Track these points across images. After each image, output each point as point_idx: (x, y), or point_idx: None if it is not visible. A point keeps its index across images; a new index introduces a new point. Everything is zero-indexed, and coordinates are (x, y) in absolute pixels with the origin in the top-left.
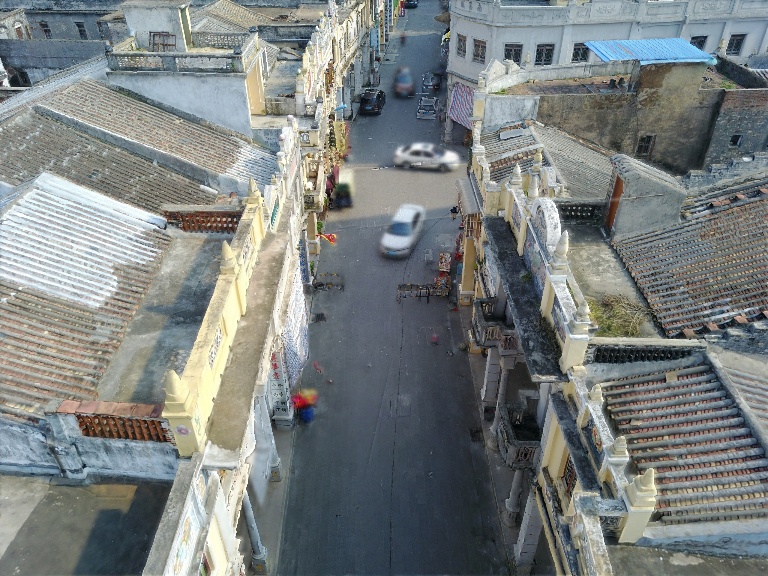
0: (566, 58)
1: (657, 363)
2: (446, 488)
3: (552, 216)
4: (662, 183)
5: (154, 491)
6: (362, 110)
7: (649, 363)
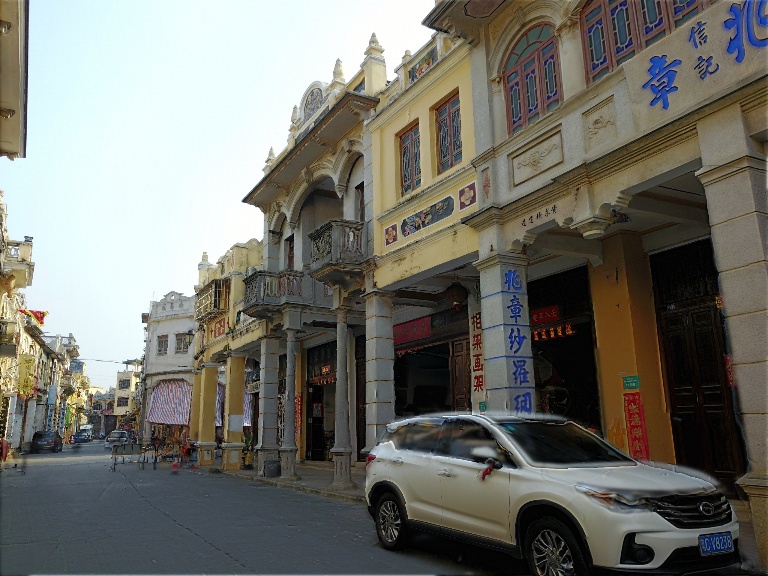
0: None
1: None
2: None
3: None
4: None
5: None
6: (33, 446)
7: None
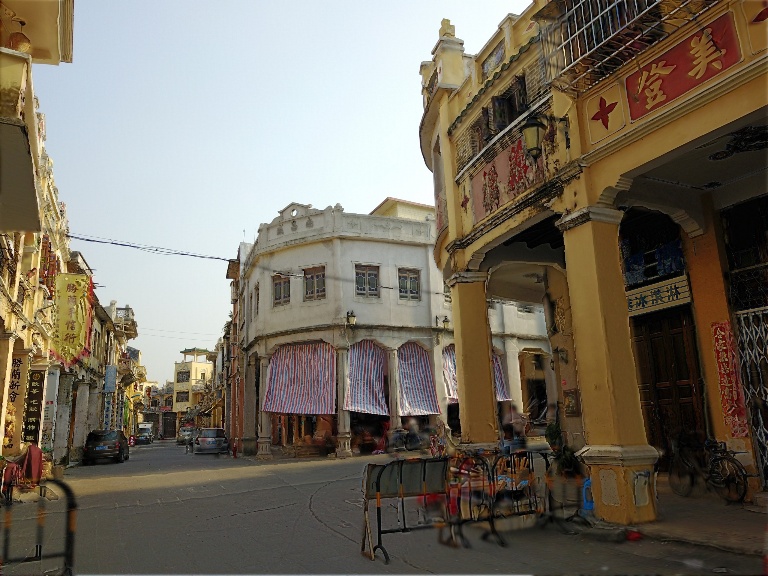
0: (438, 290)
1: None
2: None
3: None
4: None
5: None
6: (88, 454)
7: None
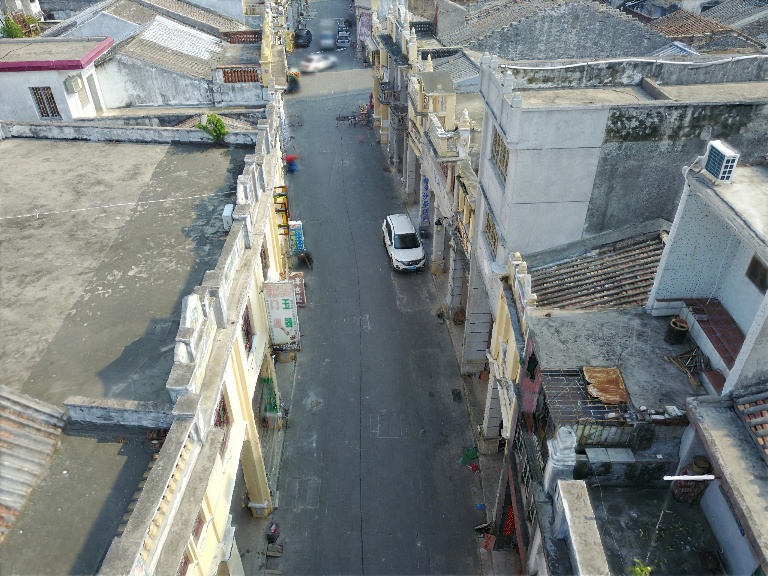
0: None
1: (446, 58)
2: (372, 186)
3: (403, 9)
4: (454, 4)
5: (252, 107)
6: (296, 43)
7: (443, 58)
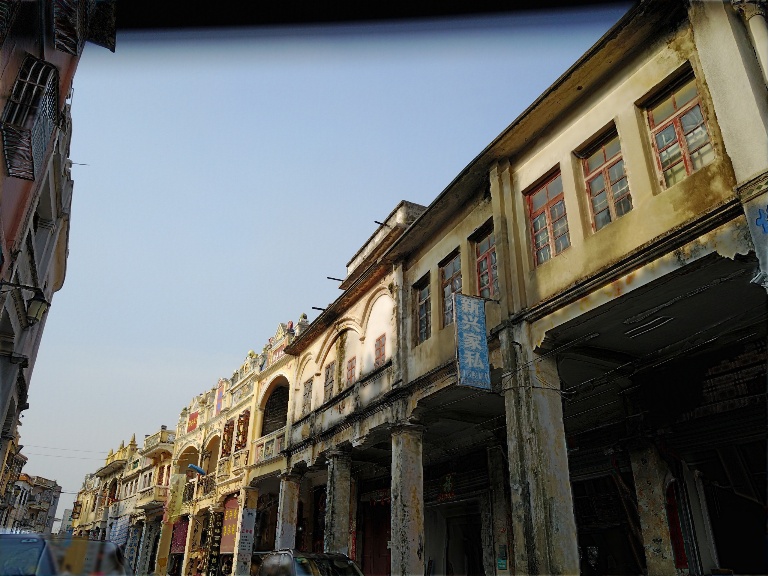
0: None
1: None
2: None
3: None
4: None
5: None
6: None
7: None
